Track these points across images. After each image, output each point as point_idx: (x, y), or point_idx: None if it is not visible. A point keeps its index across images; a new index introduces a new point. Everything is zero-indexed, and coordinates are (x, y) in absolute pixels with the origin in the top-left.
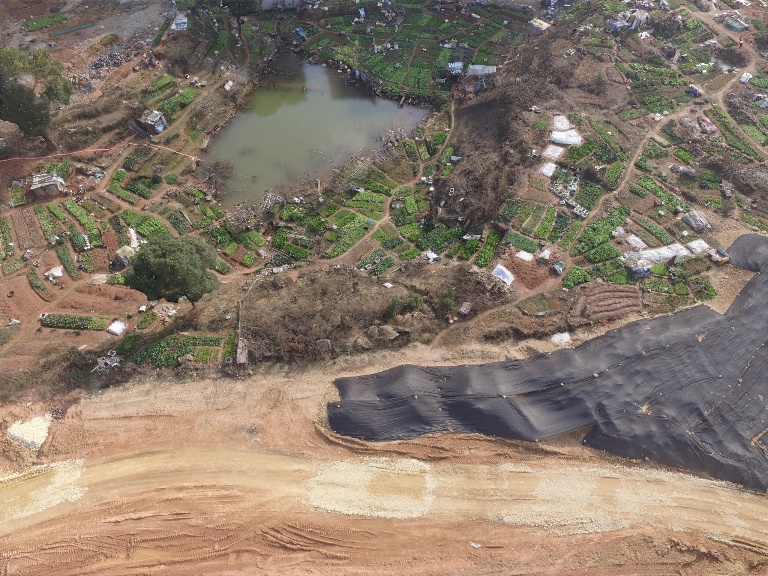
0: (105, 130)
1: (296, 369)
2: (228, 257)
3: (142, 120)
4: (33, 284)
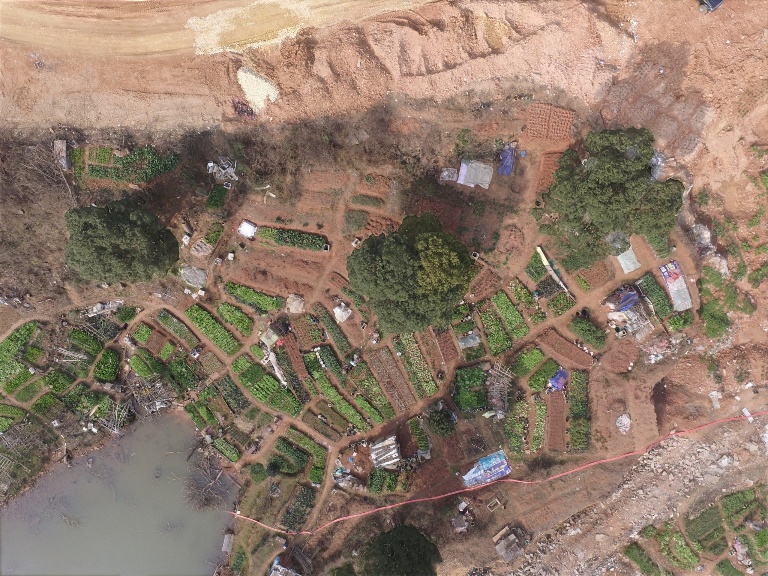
0: (339, 554)
1: (6, 131)
2: (169, 339)
3: (292, 573)
4: (357, 296)
